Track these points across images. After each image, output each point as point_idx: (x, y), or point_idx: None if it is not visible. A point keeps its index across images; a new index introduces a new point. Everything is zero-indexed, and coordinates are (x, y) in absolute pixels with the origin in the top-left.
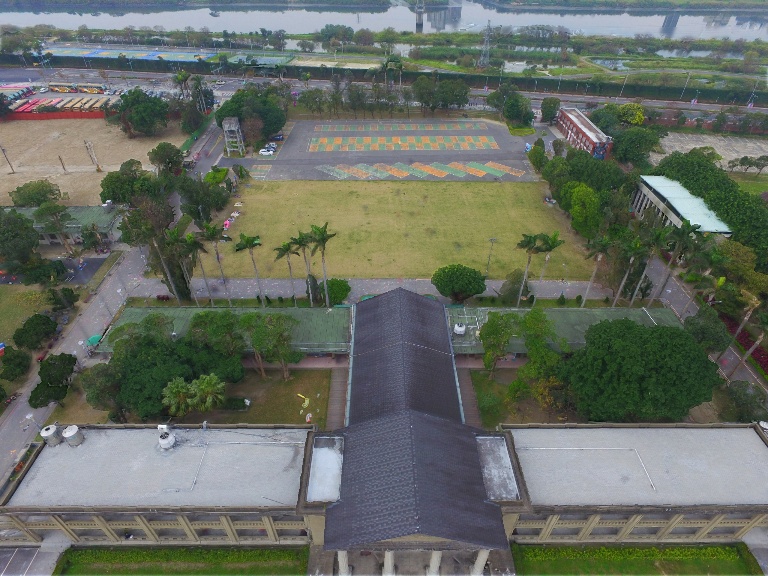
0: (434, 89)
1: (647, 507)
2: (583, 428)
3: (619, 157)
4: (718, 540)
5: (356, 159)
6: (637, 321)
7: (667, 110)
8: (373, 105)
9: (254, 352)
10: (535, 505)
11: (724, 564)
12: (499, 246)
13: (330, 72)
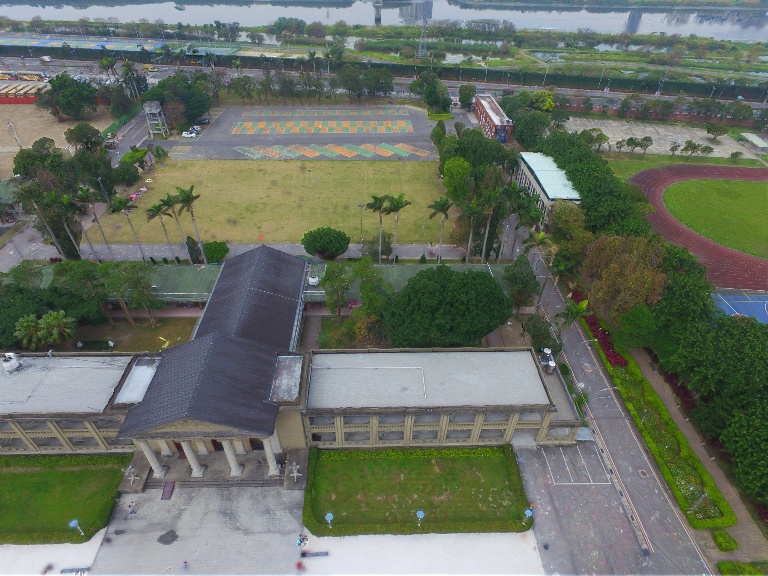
0: (359, 77)
1: (411, 408)
2: (384, 353)
3: (516, 138)
4: (491, 443)
5: (274, 141)
6: None
7: None
8: (301, 92)
9: None
10: (317, 408)
11: (490, 461)
12: (383, 216)
13: None
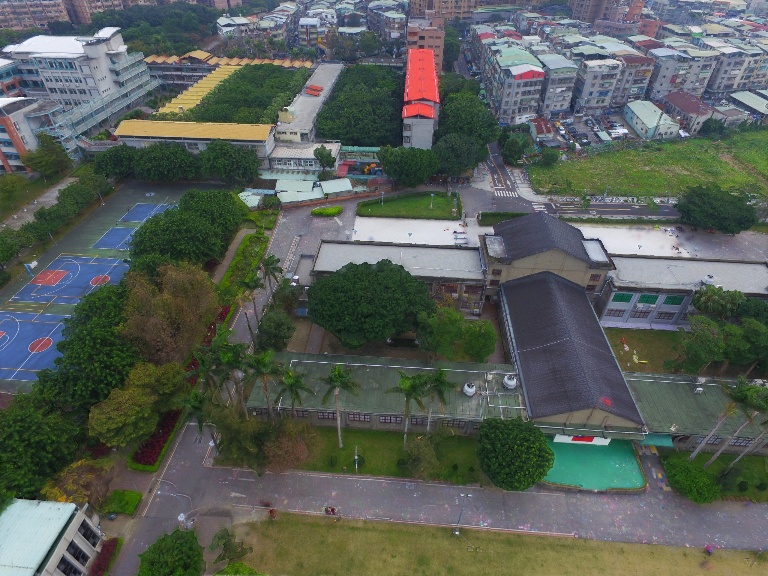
0: None
1: (413, 244)
2: None
3: None
4: None
5: None
6: None
7: None
8: None
9: None
10: (472, 247)
11: None
12: None
13: None
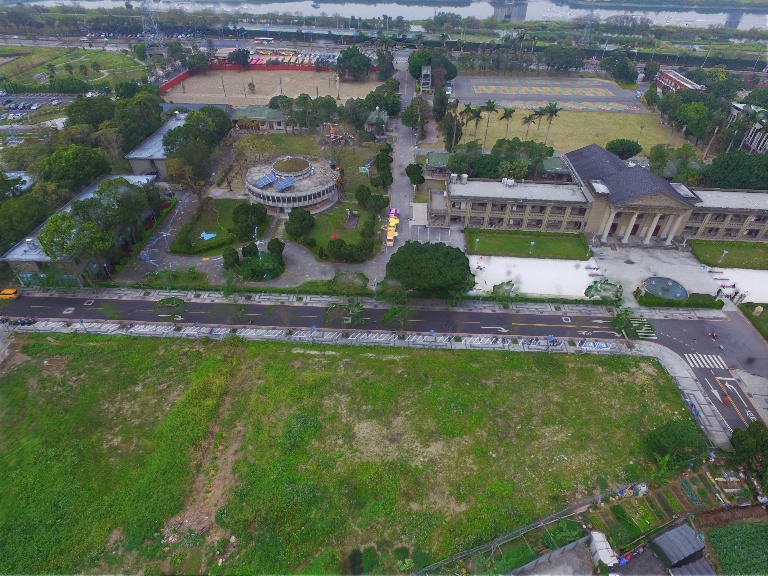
0: (560, 54)
1: (756, 209)
2: (718, 191)
3: None
4: None
5: (513, 98)
6: None
7: None
8: (513, 65)
9: None
10: (701, 206)
11: None
12: None
13: None
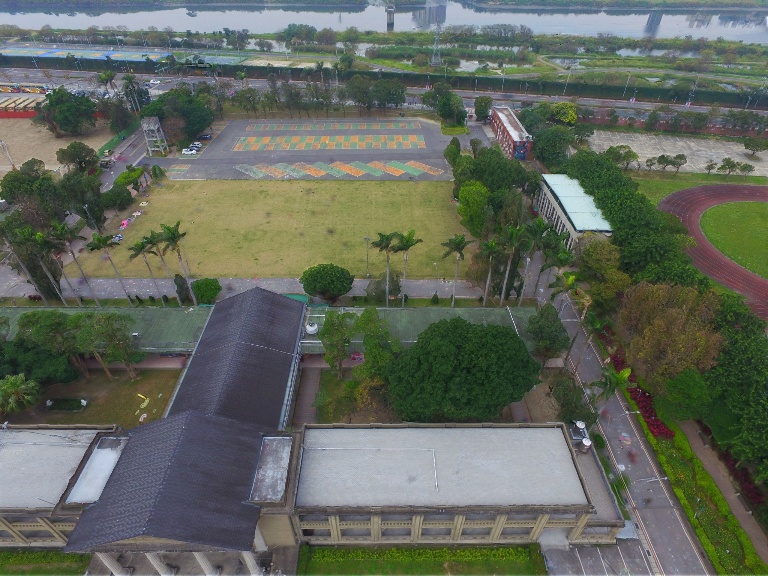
0: (368, 88)
1: (420, 508)
2: (389, 428)
3: (536, 156)
4: (514, 541)
5: (278, 158)
6: (497, 320)
7: (606, 109)
8: (307, 104)
9: (98, 352)
10: (307, 506)
11: (513, 565)
12: None
13: (277, 71)
